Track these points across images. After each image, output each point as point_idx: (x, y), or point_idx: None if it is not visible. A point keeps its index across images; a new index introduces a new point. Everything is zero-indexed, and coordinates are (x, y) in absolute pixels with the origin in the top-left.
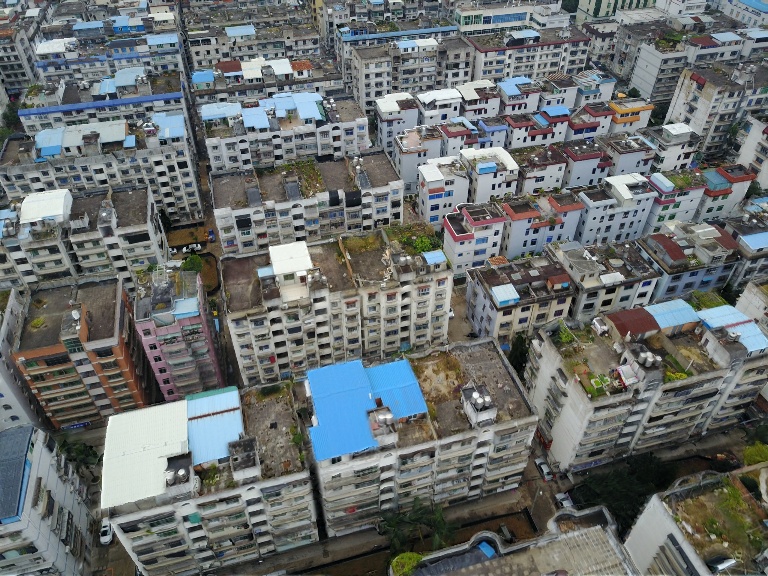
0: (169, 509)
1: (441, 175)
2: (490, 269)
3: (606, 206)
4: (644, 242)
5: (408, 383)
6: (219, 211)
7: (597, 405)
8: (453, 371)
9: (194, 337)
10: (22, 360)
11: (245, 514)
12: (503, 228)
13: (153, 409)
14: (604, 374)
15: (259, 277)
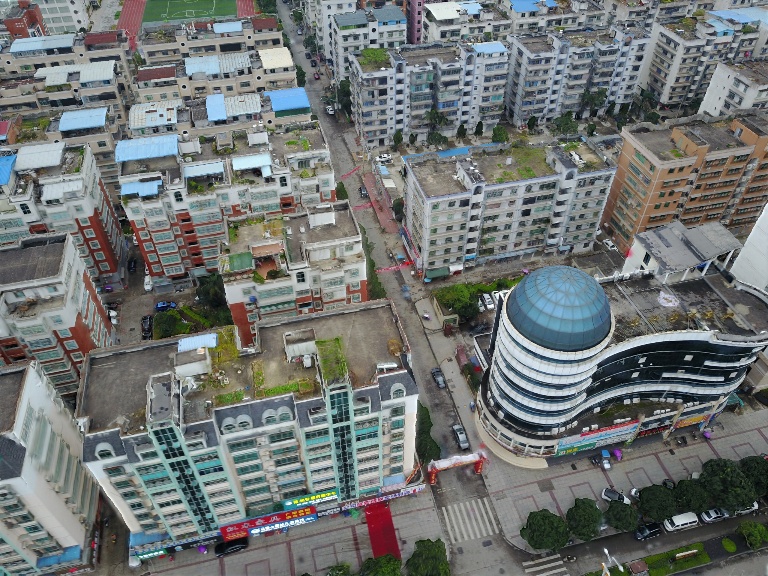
0: (459, 27)
1: None
2: None
3: None
4: None
5: None
6: None
7: (631, 10)
8: (565, 2)
9: None
10: (367, 1)
11: None
12: None
13: (441, 3)
14: None
15: None
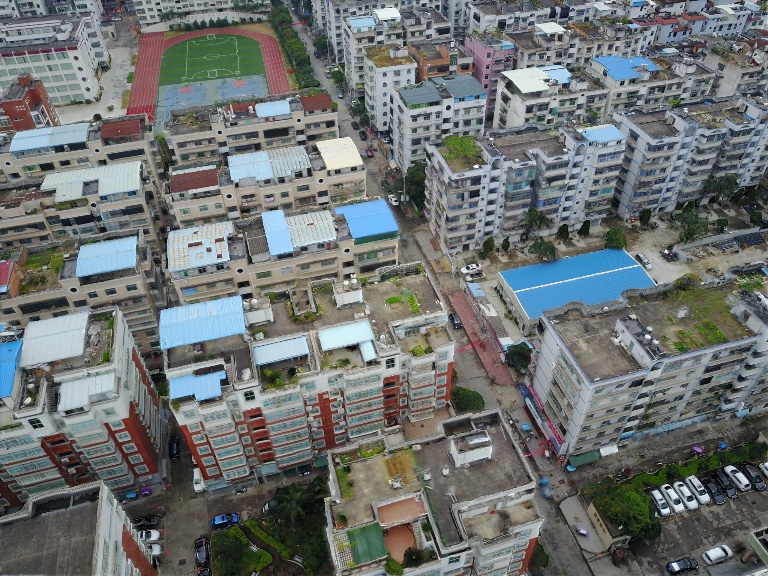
0: (548, 100)
1: (608, 7)
2: (656, 45)
3: (718, 19)
4: (746, 34)
5: (646, 61)
6: (489, 17)
7: (744, 72)
8: (663, 63)
9: (507, 64)
10: (428, 66)
11: (574, 115)
12: (656, 30)
13: (522, 69)
14: (744, 62)
15: (538, 34)
